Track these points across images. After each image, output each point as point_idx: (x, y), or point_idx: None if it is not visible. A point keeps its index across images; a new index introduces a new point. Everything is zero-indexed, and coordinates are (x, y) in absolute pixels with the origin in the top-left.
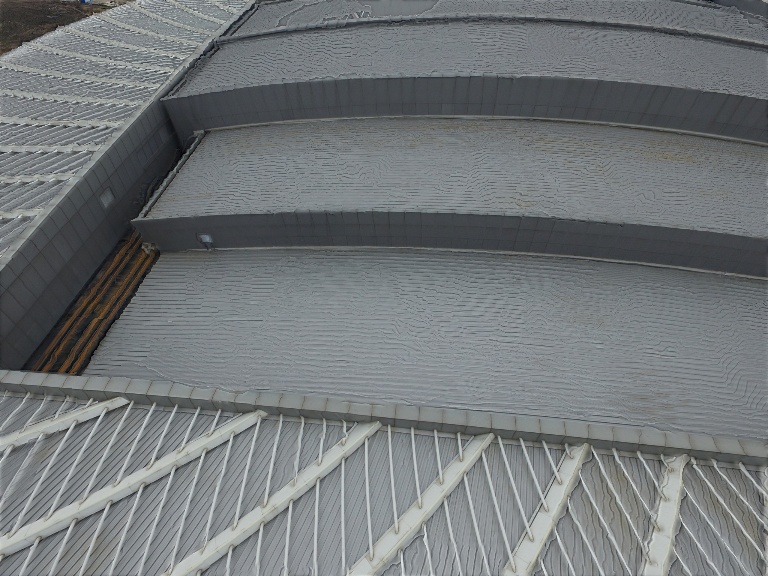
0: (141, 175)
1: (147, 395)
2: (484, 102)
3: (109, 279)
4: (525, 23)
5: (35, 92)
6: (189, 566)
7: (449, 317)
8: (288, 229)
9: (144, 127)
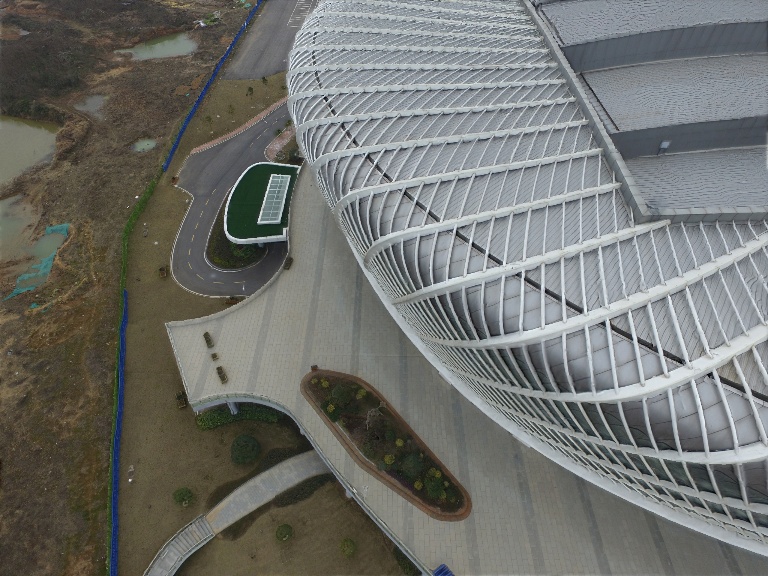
0: None
1: None
2: None
3: None
4: None
5: (434, 46)
6: None
7: None
8: (740, 132)
9: None
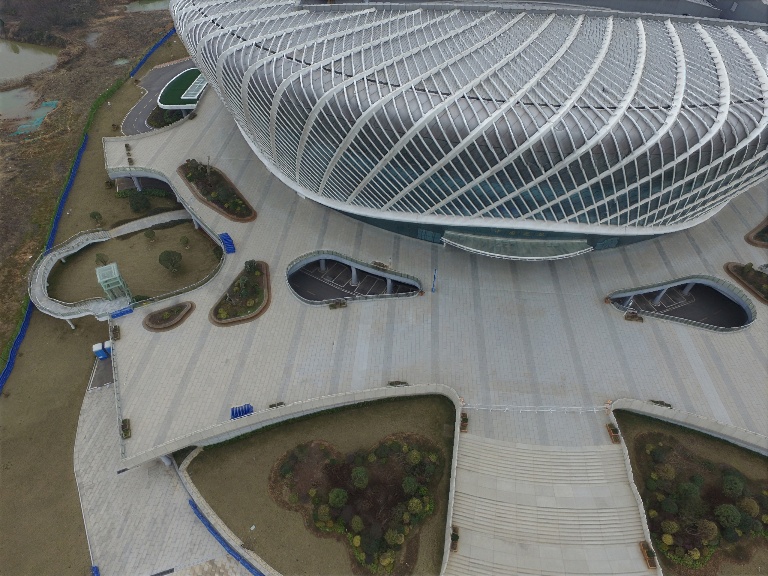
0: None
1: (383, 5)
2: None
3: None
4: None
5: None
6: (412, 27)
7: None
8: None
9: None
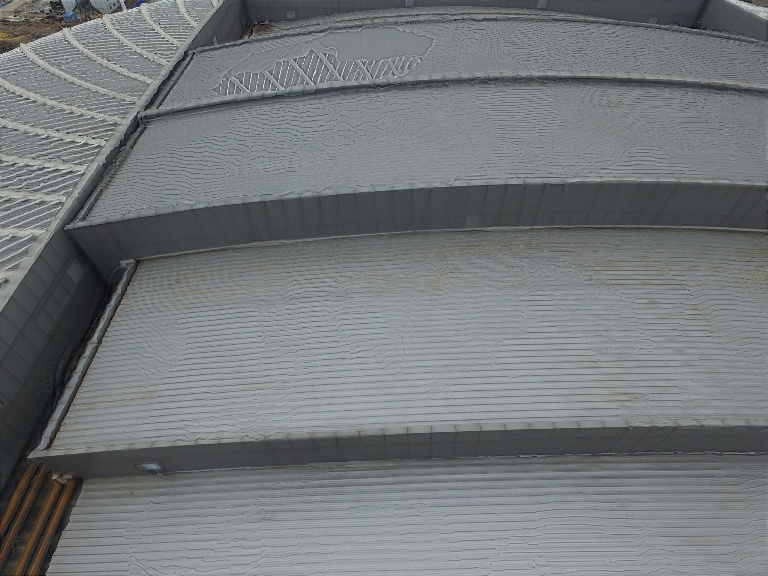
0: (45, 346)
1: None
2: (523, 212)
3: (2, 545)
4: (547, 84)
5: None
6: None
7: (530, 569)
8: (277, 453)
9: (42, 278)
